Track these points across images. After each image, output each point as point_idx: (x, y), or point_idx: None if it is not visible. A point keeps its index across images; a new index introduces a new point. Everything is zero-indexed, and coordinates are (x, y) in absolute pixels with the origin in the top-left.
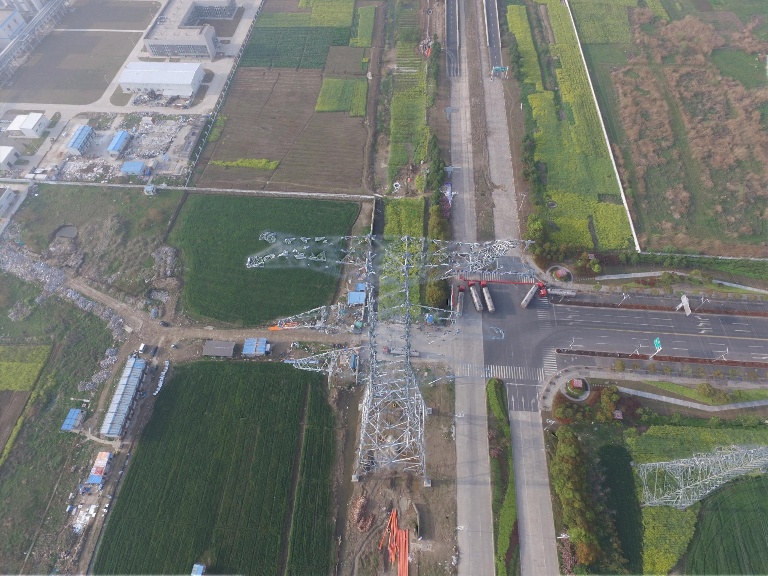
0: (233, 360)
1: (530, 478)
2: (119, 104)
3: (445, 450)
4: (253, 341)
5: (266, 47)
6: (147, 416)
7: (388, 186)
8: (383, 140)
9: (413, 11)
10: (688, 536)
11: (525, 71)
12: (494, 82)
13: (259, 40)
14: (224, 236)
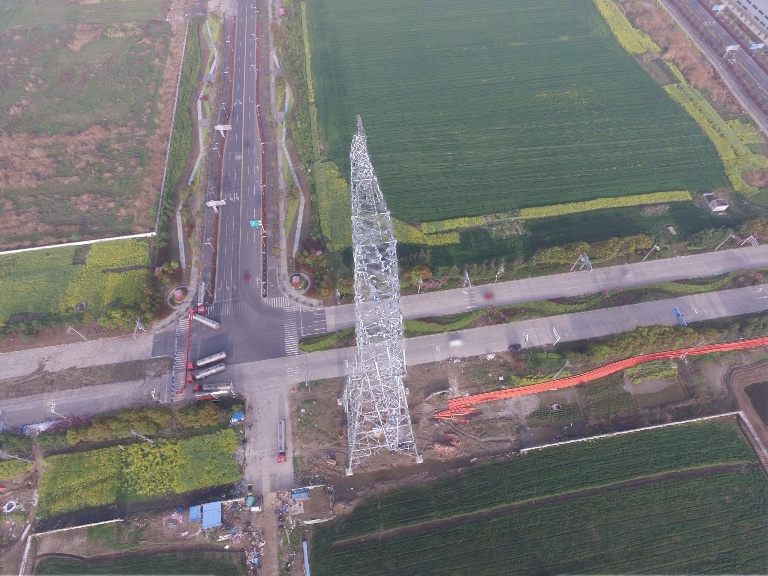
0: None
1: None
2: None
3: None
4: None
5: None
6: None
7: (8, 521)
8: None
9: None
10: (395, 220)
11: None
12: None
13: None
14: None
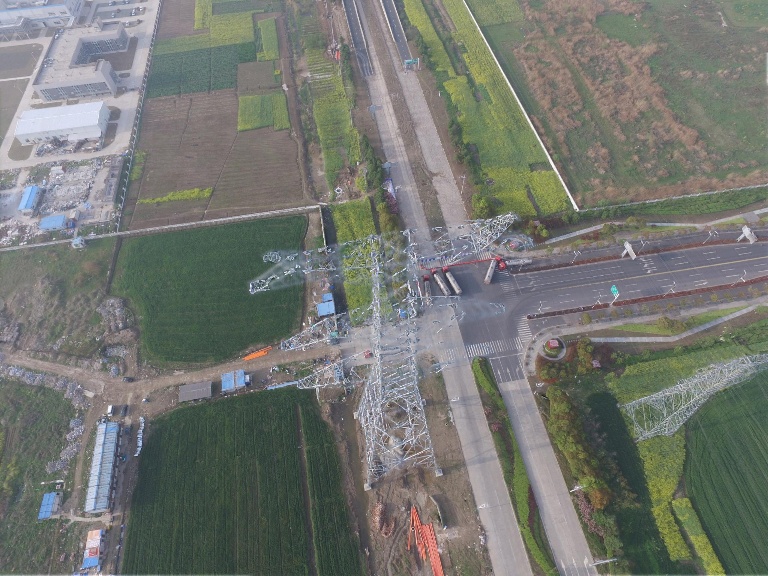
0: (213, 400)
1: (532, 442)
2: (20, 158)
3: (448, 436)
4: (230, 375)
5: (170, 74)
6: (133, 480)
7: (330, 193)
8: (314, 148)
9: (313, 18)
10: (681, 458)
11: (435, 60)
12: (408, 75)
13: (161, 68)
14: (172, 275)
